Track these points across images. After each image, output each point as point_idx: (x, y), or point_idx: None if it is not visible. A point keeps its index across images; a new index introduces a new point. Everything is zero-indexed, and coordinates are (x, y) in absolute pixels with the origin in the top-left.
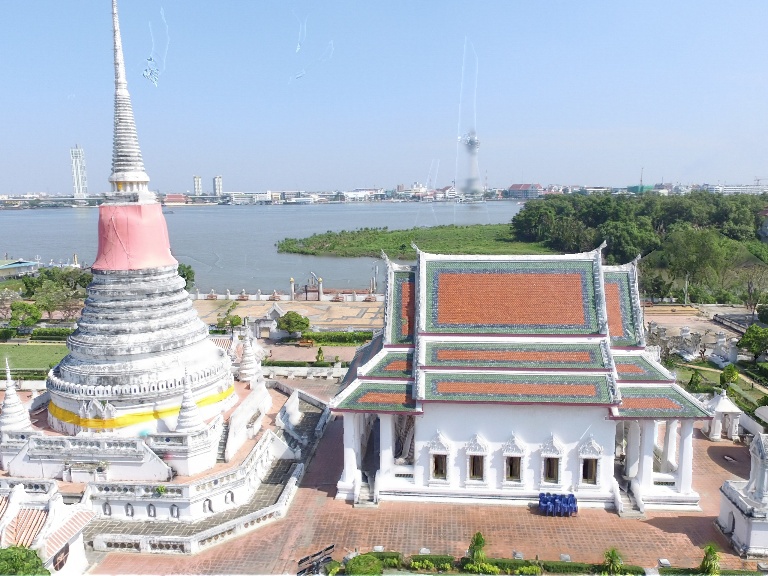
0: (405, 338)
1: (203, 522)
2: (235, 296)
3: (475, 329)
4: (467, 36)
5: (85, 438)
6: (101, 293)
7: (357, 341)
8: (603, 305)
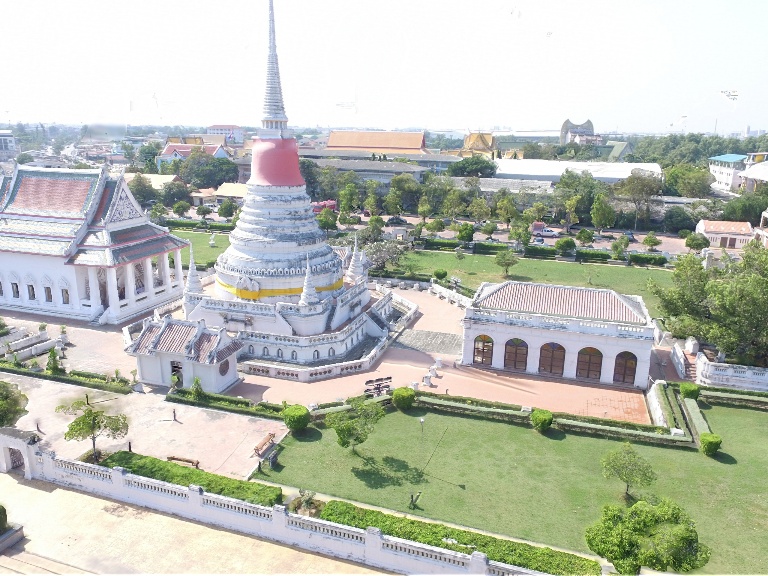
0: None
1: None
2: None
3: None
4: None
5: None
6: None
7: None
8: None
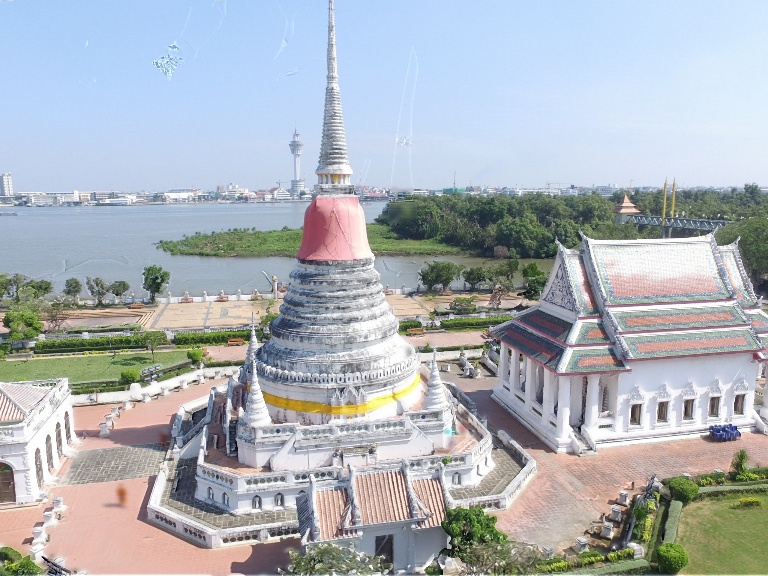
0: (592, 311)
1: (482, 485)
2: (213, 298)
3: (646, 300)
4: (413, 45)
5: (354, 423)
6: (329, 283)
7: (399, 330)
8: None
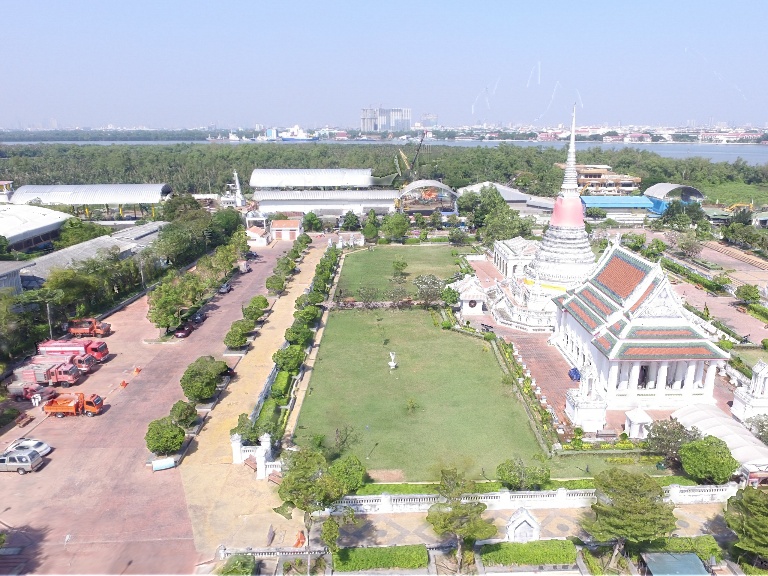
0: None
1: None
2: None
3: None
4: None
5: None
6: None
7: None
8: (635, 292)
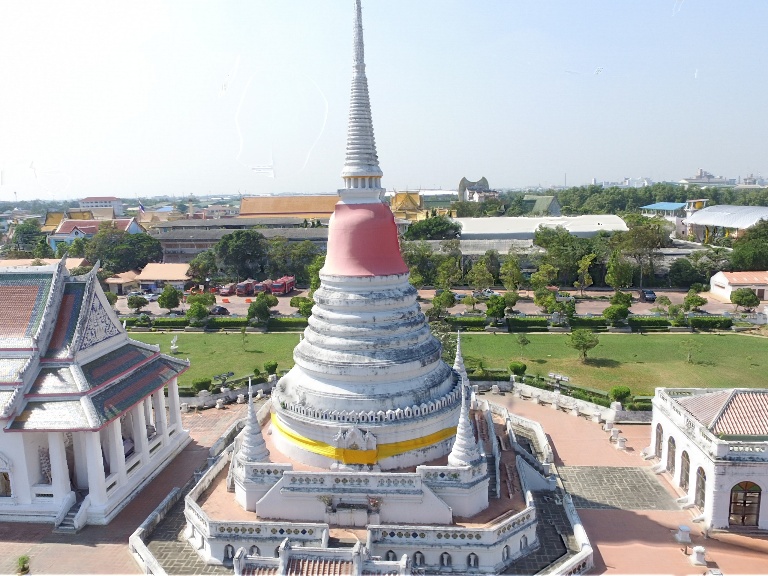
0: None
1: None
2: None
3: None
4: None
5: None
6: None
7: None
8: None
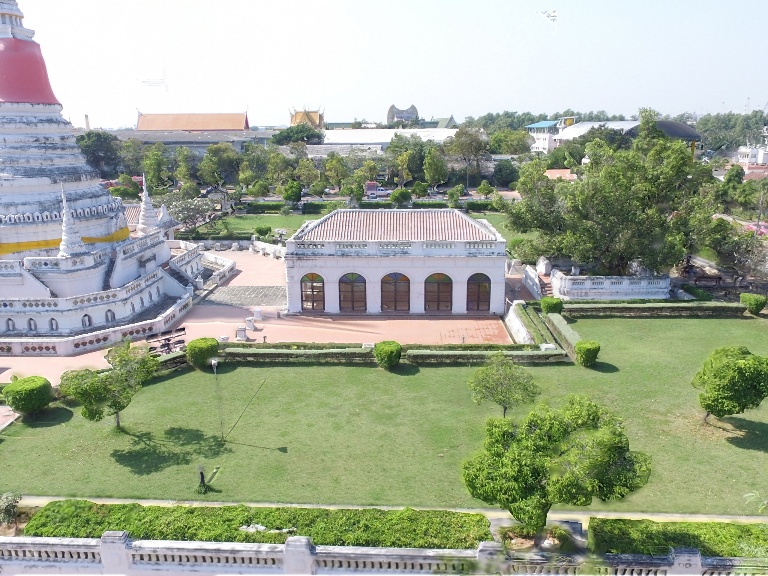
0: None
1: None
2: None
3: None
4: None
5: None
6: None
7: None
8: None
